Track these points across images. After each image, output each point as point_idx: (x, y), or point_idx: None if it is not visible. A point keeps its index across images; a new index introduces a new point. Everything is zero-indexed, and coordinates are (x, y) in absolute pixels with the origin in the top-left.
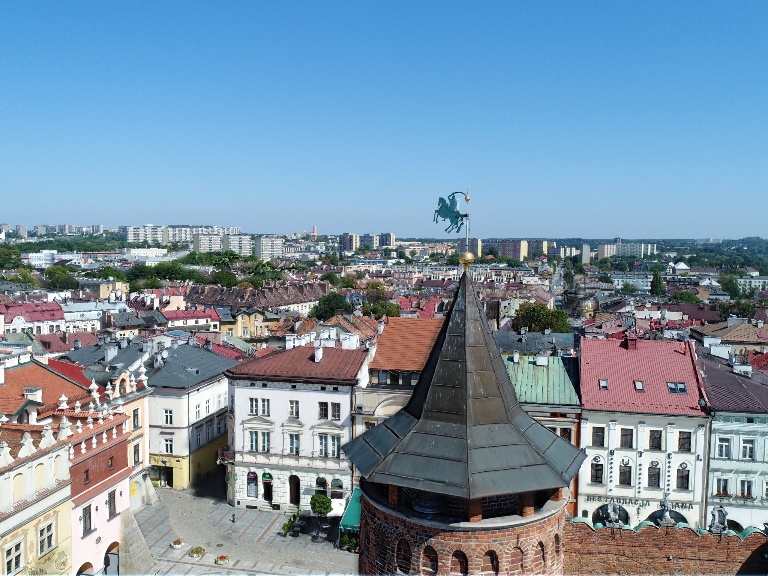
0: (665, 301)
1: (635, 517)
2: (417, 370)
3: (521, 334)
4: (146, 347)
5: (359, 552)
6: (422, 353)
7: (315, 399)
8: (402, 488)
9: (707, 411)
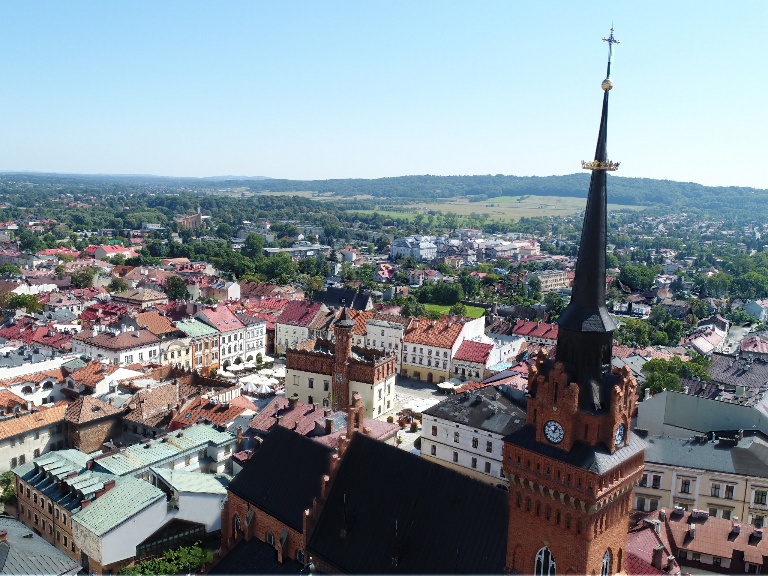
0: (7, 275)
1: (232, 362)
2: (165, 332)
3: (43, 314)
4: (41, 351)
5: (342, 334)
6: (159, 326)
7: (148, 350)
8: (344, 327)
9: (246, 325)
